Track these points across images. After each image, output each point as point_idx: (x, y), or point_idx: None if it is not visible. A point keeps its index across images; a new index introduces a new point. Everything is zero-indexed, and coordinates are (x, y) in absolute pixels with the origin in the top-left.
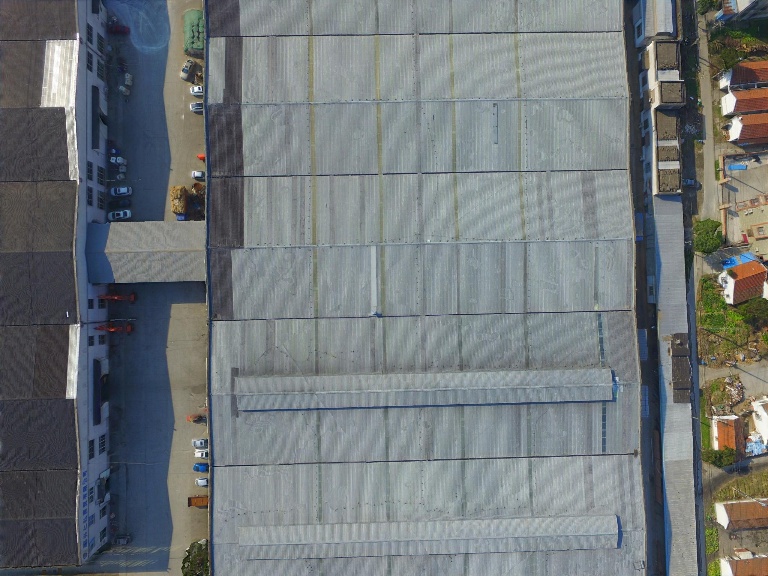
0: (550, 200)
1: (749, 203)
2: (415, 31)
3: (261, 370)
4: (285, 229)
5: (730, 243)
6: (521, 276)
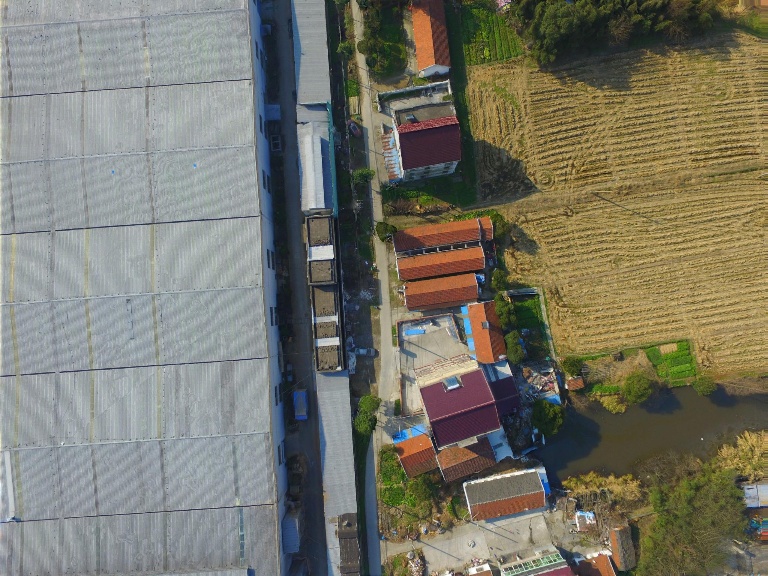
0: (188, 394)
1: None
2: (51, 228)
3: None
4: None
5: (409, 411)
6: (158, 474)
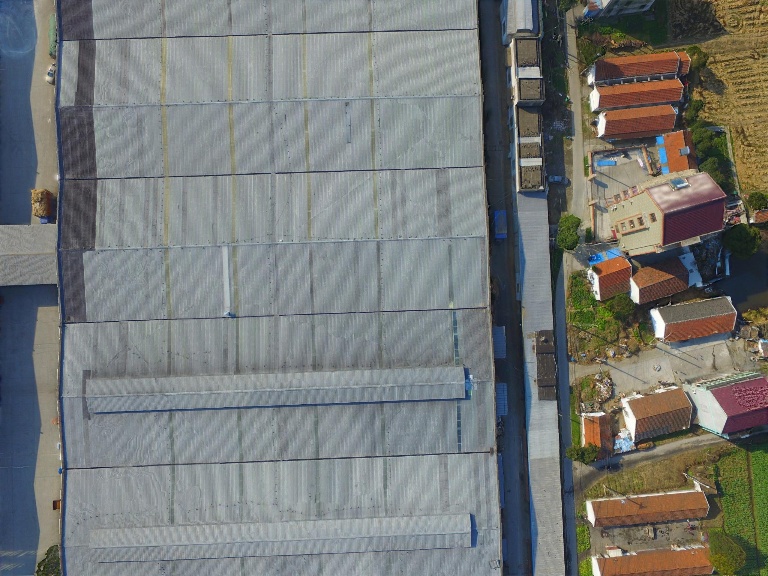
0: (404, 198)
1: (613, 199)
2: (269, 31)
3: (113, 372)
4: (137, 231)
5: (600, 239)
6: (374, 275)
